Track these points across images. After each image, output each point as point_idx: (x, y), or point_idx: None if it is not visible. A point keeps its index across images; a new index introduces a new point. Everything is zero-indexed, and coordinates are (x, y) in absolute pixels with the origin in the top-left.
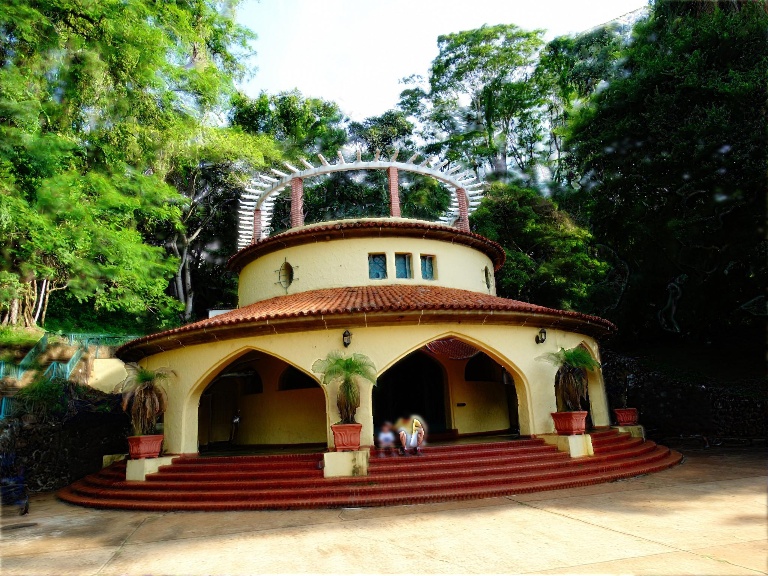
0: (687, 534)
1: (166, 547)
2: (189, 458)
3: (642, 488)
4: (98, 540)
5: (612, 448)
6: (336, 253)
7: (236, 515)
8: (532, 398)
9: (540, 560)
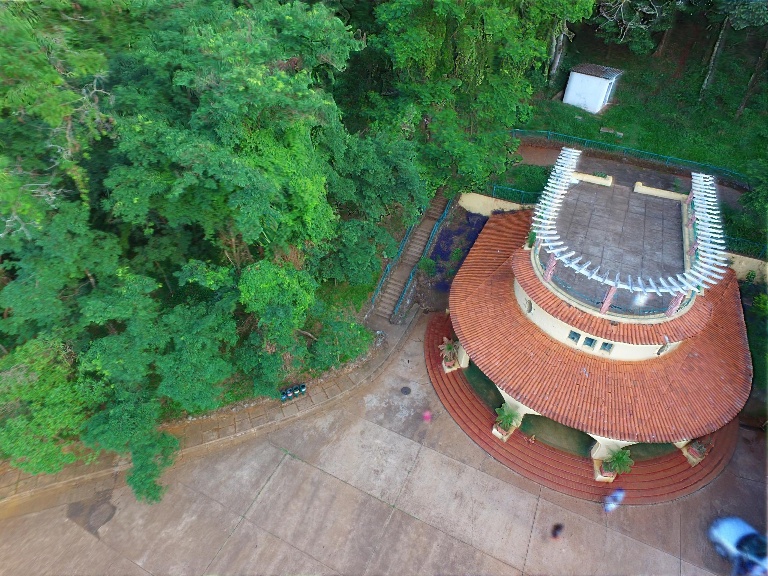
0: (539, 566)
1: (429, 457)
2: (461, 376)
3: (594, 520)
4: (418, 433)
5: (630, 482)
6: (554, 320)
7: (458, 434)
8: (599, 450)
9: (489, 547)
